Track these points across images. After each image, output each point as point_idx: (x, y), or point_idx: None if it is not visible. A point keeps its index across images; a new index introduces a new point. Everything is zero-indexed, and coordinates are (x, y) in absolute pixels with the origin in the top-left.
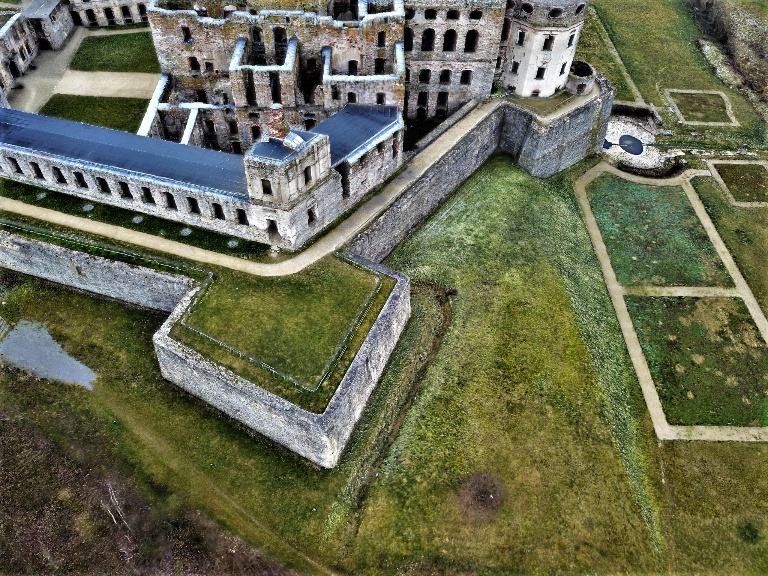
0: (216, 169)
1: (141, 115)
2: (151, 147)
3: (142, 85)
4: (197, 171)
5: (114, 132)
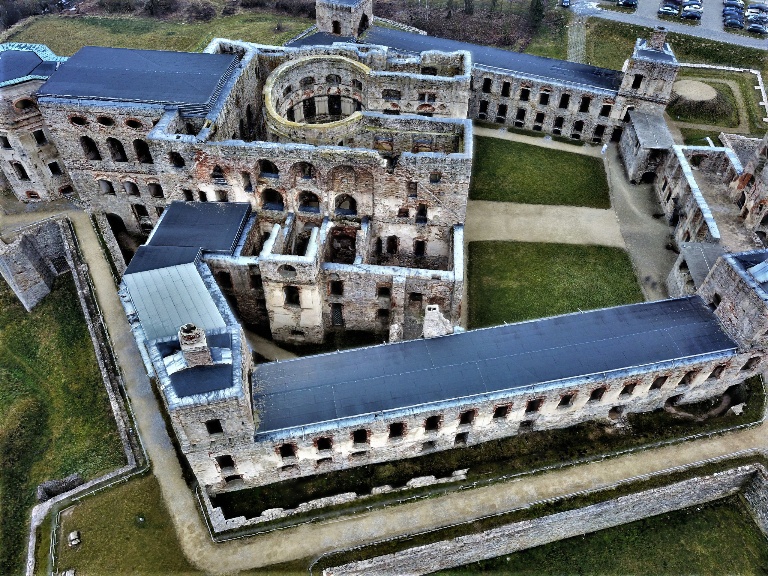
0: (396, 37)
1: (499, 180)
2: (446, 51)
3: (517, 222)
4: (409, 37)
5: (480, 62)
